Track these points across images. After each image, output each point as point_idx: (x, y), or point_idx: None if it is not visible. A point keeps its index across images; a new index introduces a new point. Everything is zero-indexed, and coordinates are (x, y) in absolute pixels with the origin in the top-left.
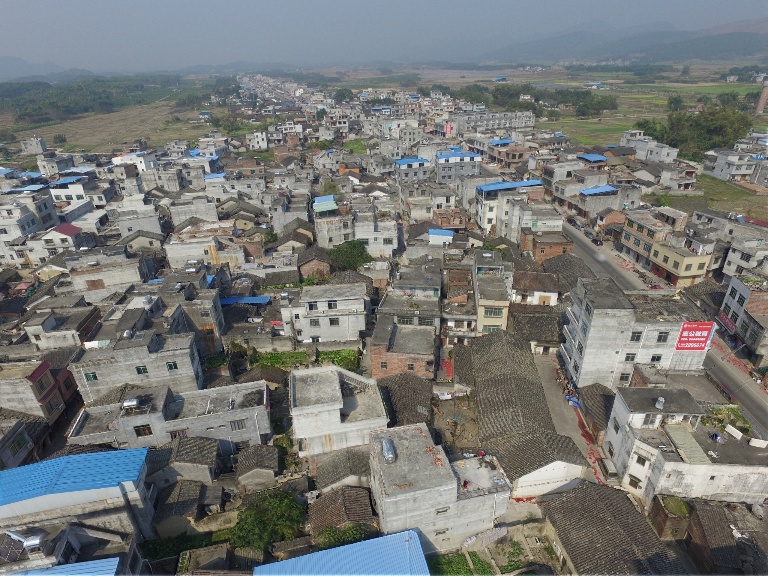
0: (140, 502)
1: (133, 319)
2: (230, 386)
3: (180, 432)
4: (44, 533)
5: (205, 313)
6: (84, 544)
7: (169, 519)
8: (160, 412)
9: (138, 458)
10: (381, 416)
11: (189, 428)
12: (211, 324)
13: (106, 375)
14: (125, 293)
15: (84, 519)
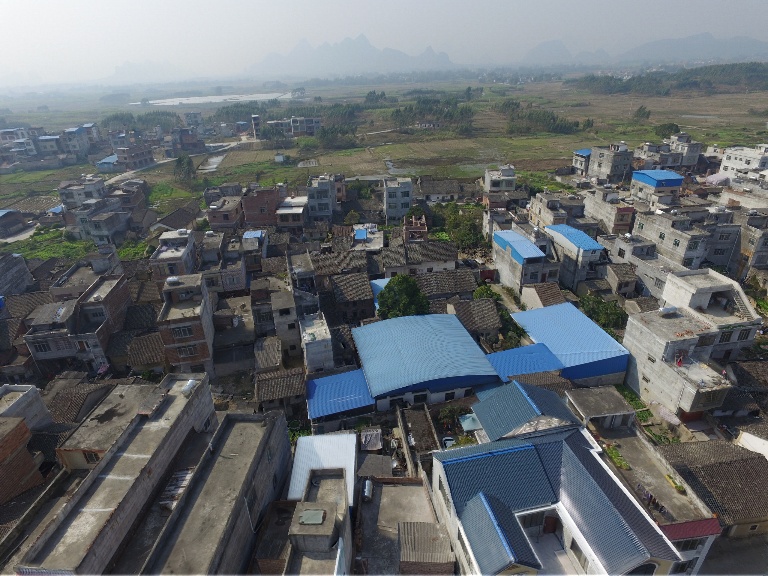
0: (580, 265)
1: (692, 210)
2: (683, 267)
3: (634, 267)
4: (544, 236)
5: (752, 241)
6: (550, 254)
7: (583, 284)
8: (633, 246)
9: (596, 247)
10: (715, 323)
11: (638, 267)
12: (750, 252)
13: (647, 229)
14: (725, 206)
15: (555, 242)
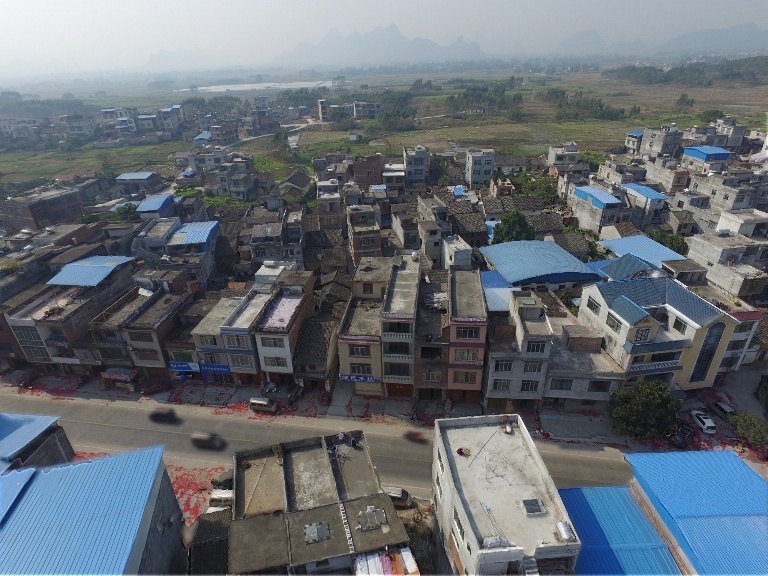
0: (648, 212)
1: (739, 172)
2: None
3: (691, 215)
4: (619, 189)
5: None
6: None
7: (649, 227)
8: (691, 198)
9: None
10: None
11: (695, 214)
12: None
13: (701, 188)
14: None
15: (628, 193)
